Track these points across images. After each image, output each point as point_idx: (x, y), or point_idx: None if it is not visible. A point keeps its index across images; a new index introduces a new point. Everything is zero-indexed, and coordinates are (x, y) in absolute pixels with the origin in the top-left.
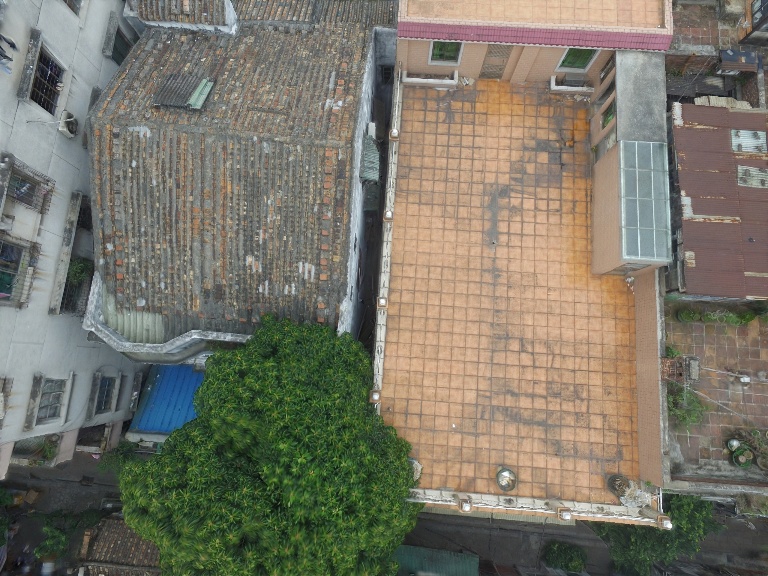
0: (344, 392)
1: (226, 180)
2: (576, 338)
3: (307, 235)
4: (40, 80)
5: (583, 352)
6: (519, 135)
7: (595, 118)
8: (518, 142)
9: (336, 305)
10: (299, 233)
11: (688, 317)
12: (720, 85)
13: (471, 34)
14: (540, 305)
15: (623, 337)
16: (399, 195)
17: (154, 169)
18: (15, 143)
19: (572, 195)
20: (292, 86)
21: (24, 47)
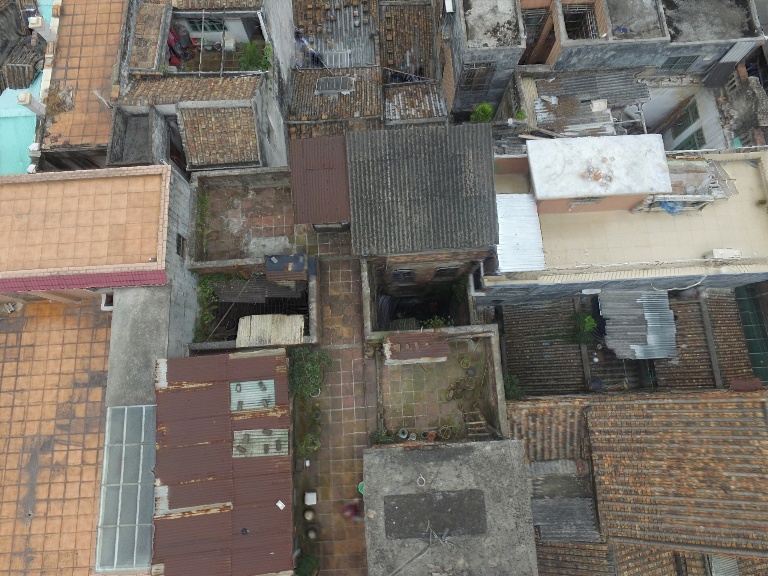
0: None
1: None
2: None
3: None
4: None
5: None
6: (70, 369)
7: None
8: (68, 378)
9: None
10: None
11: None
12: (291, 285)
13: None
14: None
15: None
16: None
17: None
18: None
19: None
20: None
21: None
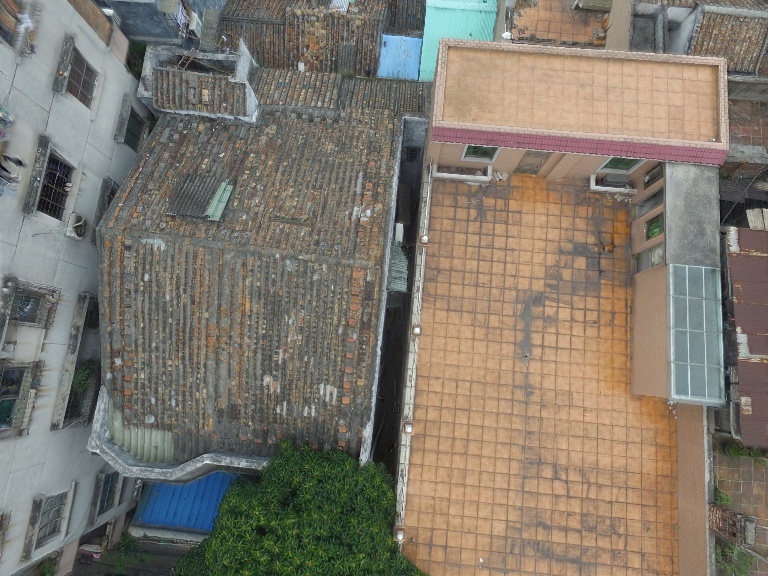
0: (369, 548)
1: (245, 298)
2: (613, 465)
3: (330, 357)
4: (47, 186)
5: (621, 481)
6: (555, 237)
7: (638, 224)
8: (554, 245)
9: (359, 429)
10: (321, 354)
11: (737, 453)
12: None
13: (511, 141)
14: (575, 427)
15: (664, 466)
16: (426, 300)
17: (168, 284)
18: (19, 261)
19: (611, 305)
20: (317, 190)
21: (31, 158)
